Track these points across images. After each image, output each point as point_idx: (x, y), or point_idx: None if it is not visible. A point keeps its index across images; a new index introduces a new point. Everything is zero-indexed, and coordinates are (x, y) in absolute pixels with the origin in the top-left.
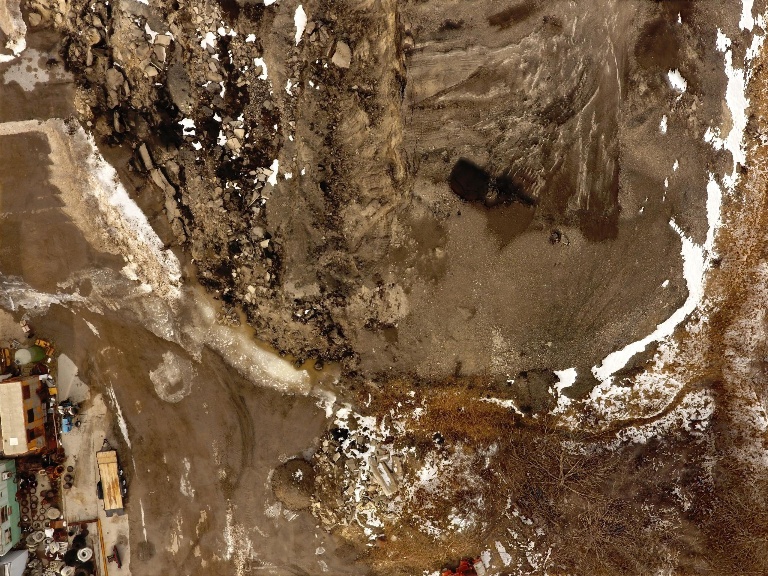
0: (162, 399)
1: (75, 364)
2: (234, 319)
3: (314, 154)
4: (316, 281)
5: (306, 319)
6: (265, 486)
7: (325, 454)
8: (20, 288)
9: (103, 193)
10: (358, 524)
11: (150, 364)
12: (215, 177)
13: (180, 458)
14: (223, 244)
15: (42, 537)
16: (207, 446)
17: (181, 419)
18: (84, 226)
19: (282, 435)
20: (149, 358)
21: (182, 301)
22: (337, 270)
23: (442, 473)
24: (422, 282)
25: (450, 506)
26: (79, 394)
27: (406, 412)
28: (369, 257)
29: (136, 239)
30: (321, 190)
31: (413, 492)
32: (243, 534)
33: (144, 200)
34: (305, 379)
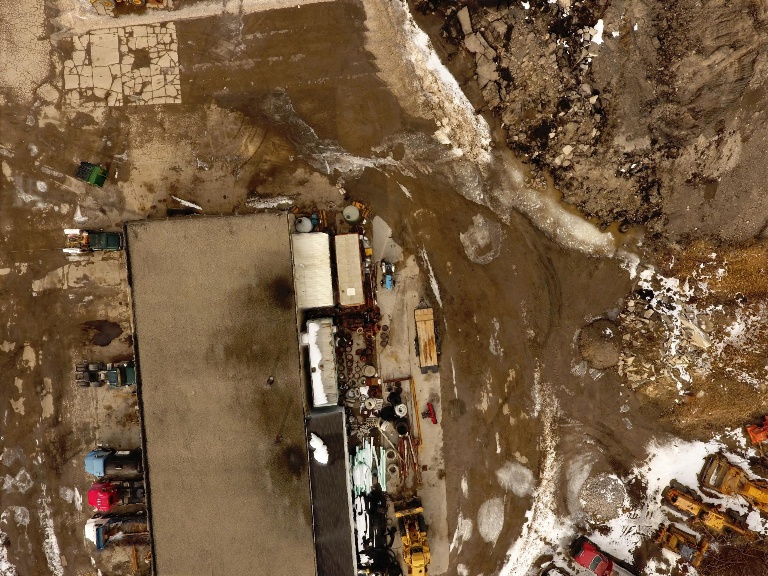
0: (472, 261)
1: (389, 226)
2: (543, 182)
3: (647, 10)
4: (647, 134)
5: (633, 173)
6: (571, 346)
7: (633, 313)
8: (335, 152)
9: (421, 57)
10: (672, 378)
11: (461, 226)
12: (548, 34)
13: (490, 318)
14: (550, 101)
15: (359, 394)
16: (516, 306)
17: (491, 280)
18: (400, 91)
19: (588, 296)
20: (460, 220)
21: (491, 165)
22: (666, 124)
23: (748, 330)
24: (765, 128)
25: (765, 358)
26: (393, 255)
27: (710, 272)
28: (711, 105)
29: (452, 102)
30: (659, 43)
31: (722, 348)
32: (550, 392)
33: (455, 66)
34: (610, 241)
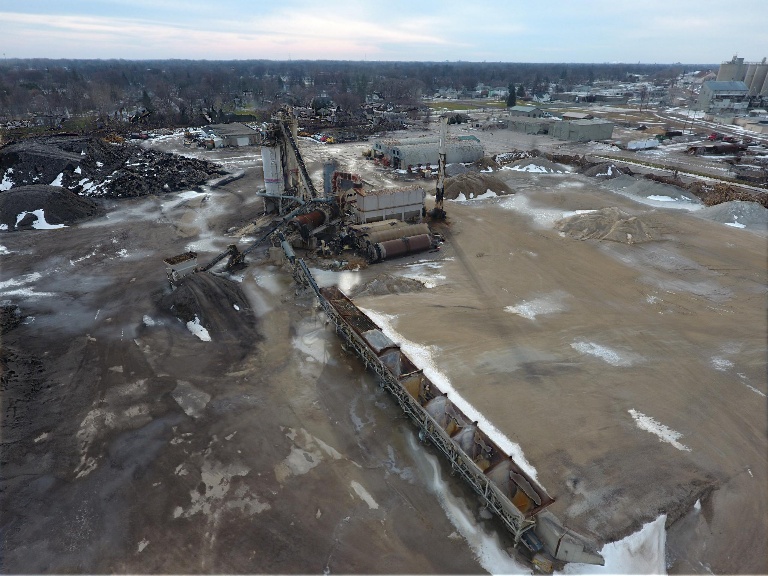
0: None
1: None
2: None
3: None
4: None
5: None
6: None
7: None
8: None
9: None
10: None
11: None
12: None
13: None
14: None
15: None
16: None
17: None
18: None
19: None
20: None
21: None
22: None
23: None
24: None
25: None
26: None
27: None
28: None
29: None
30: None
31: None
32: None
33: None
34: None
